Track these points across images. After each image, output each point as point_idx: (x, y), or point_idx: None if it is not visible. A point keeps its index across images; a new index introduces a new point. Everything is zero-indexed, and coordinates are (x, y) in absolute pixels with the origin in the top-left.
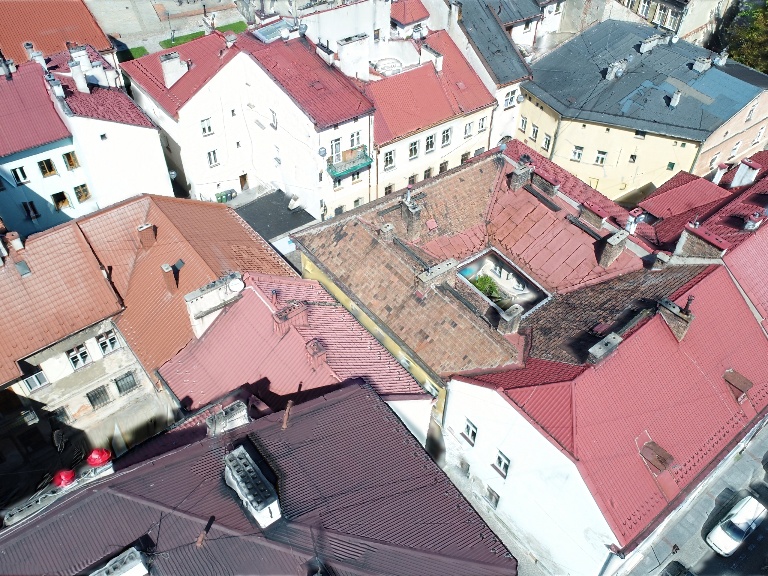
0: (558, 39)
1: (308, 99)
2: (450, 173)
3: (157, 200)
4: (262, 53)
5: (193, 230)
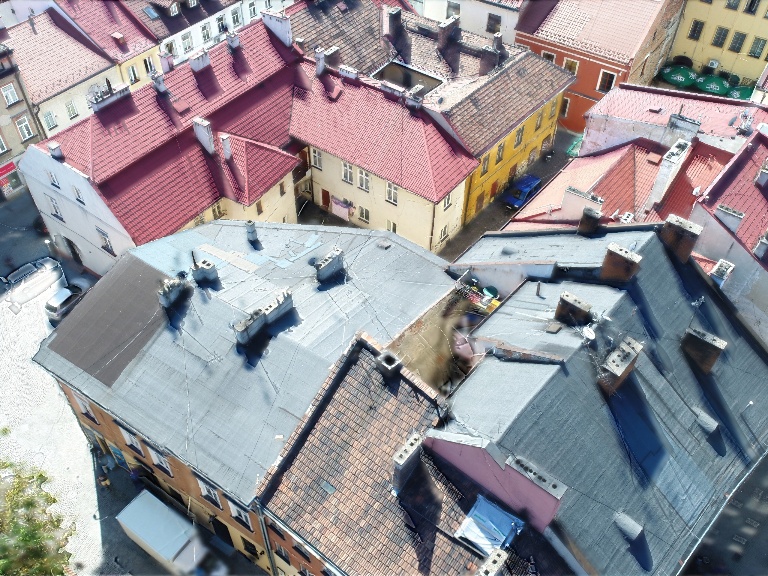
0: (430, 351)
1: (652, 99)
2: (481, 108)
3: (657, 5)
4: (749, 113)
5: (616, 3)
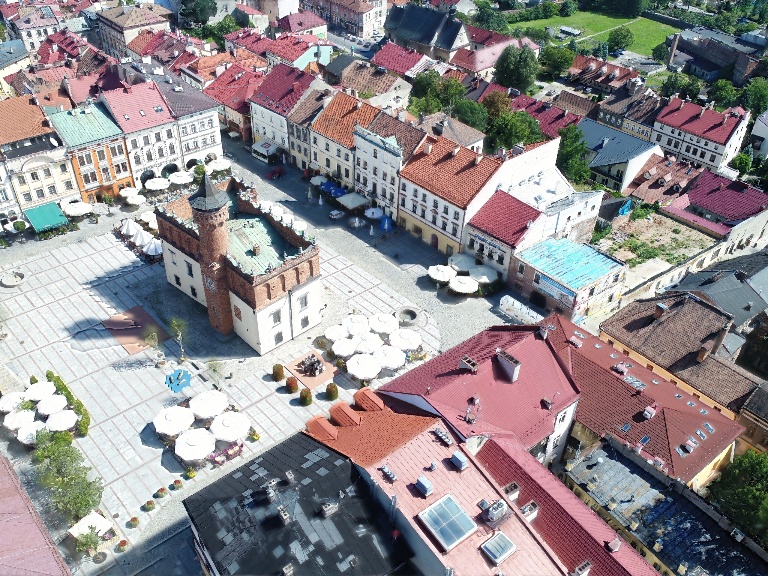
0: None
1: None
2: None
3: None
4: None
5: None
